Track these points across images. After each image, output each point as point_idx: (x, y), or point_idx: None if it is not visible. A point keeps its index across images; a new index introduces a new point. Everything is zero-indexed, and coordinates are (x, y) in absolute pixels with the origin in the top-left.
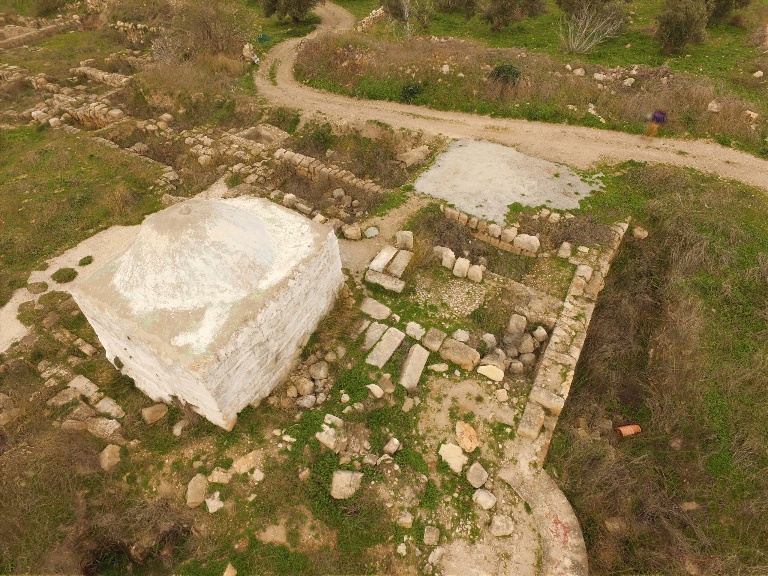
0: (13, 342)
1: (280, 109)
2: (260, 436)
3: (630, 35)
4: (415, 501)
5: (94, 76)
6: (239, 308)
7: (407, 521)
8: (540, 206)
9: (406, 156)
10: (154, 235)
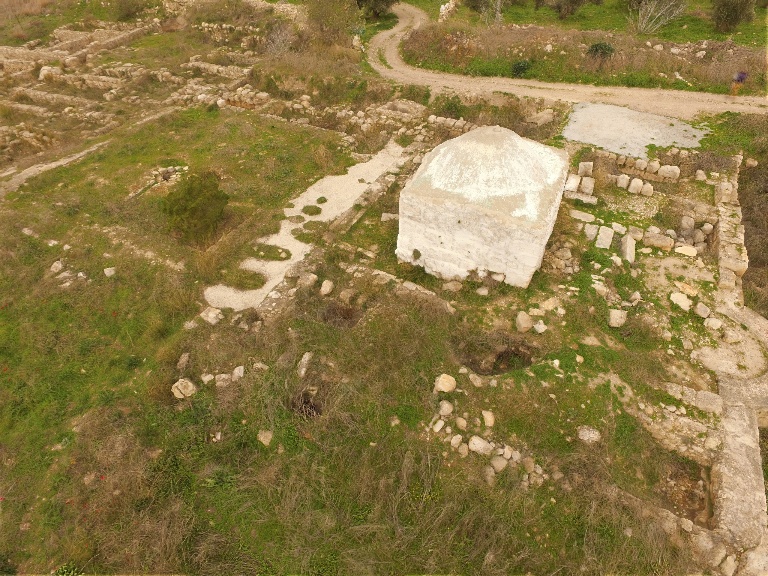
0: (305, 254)
1: (412, 86)
2: (550, 290)
3: (682, 19)
4: (669, 325)
5: (208, 69)
6: (544, 195)
7: (669, 335)
8: (670, 146)
9: (535, 118)
10: (482, 146)
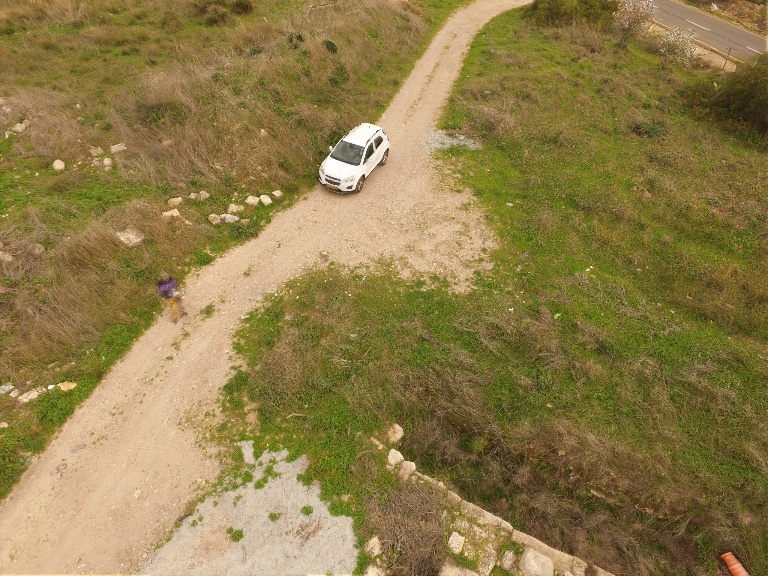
0: None
1: None
2: None
3: None
4: None
5: None
6: None
7: None
8: None
9: None
10: None
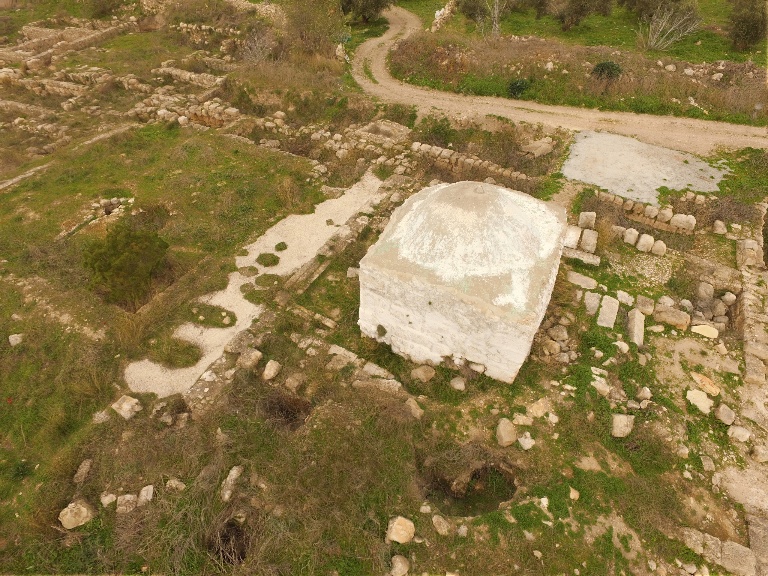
0: (252, 319)
1: (397, 105)
2: (540, 387)
3: (696, 33)
4: (686, 436)
5: (180, 76)
6: (535, 274)
7: (686, 452)
8: (684, 189)
9: (532, 147)
10: (460, 212)
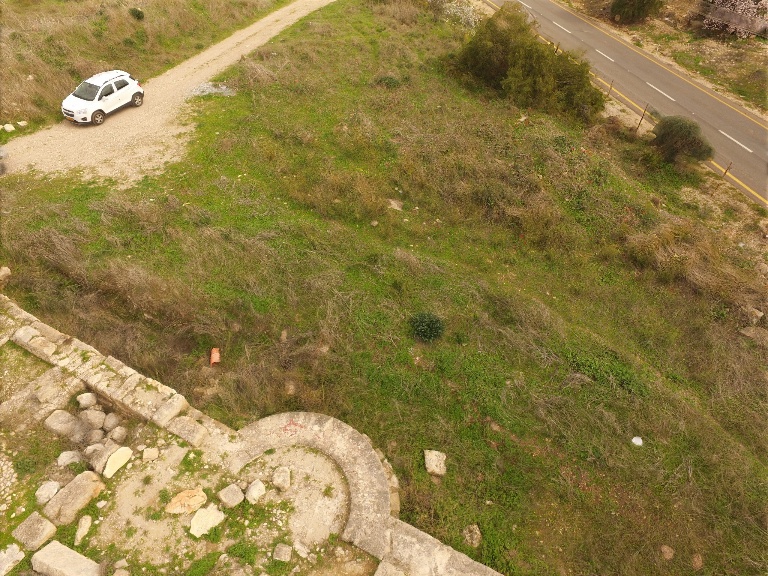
0: None
1: None
2: None
3: None
4: (247, 569)
5: None
6: None
7: None
8: None
9: None
10: None
